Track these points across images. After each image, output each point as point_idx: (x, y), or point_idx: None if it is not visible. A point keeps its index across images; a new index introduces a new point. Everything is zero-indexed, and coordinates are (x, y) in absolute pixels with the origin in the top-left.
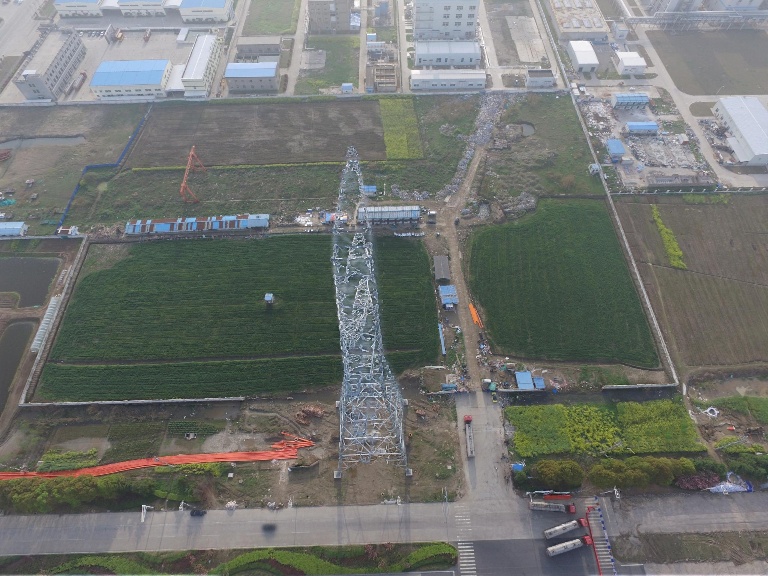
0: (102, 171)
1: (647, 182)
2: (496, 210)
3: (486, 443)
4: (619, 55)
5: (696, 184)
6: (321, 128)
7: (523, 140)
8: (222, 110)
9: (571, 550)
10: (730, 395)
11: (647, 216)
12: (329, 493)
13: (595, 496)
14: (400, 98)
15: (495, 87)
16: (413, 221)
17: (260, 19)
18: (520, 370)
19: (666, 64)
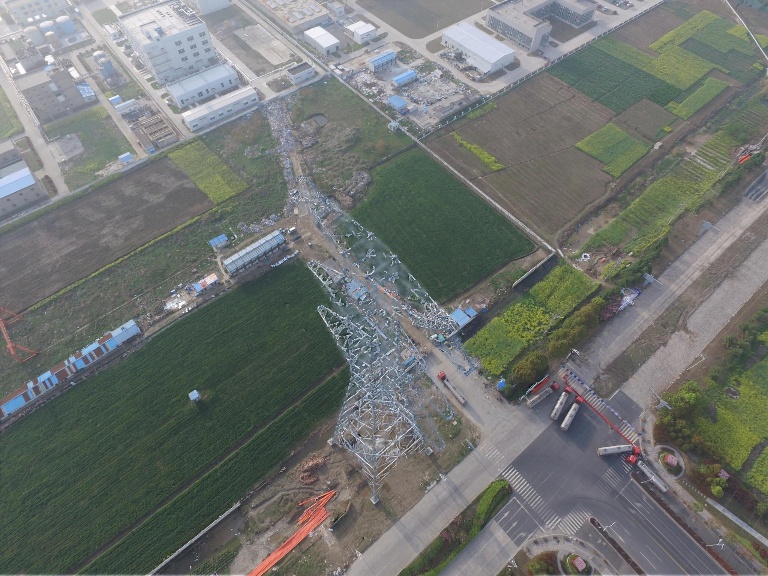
0: None
1: (437, 118)
2: (343, 198)
3: (467, 384)
4: (350, 28)
5: (469, 103)
6: (126, 209)
7: (323, 130)
8: None
9: (575, 415)
10: (587, 238)
11: (454, 143)
12: (379, 520)
13: (562, 366)
14: (187, 144)
15: (268, 96)
16: (280, 246)
17: None
18: (450, 312)
19: (388, 22)
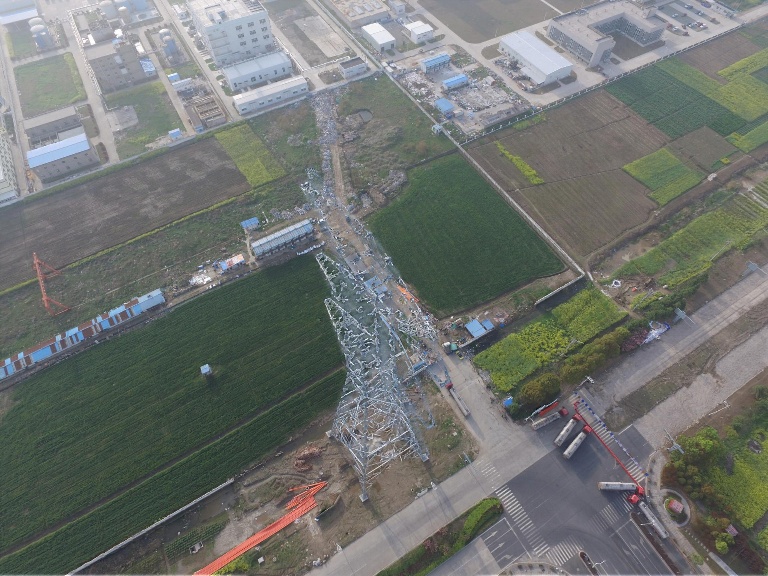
0: None
1: (482, 125)
2: (376, 195)
3: (473, 397)
4: (408, 27)
5: (518, 113)
6: (168, 183)
7: (367, 126)
8: (44, 204)
9: (581, 444)
10: (621, 265)
11: (496, 152)
12: (365, 518)
13: (574, 392)
14: (234, 126)
15: (318, 87)
16: (308, 235)
17: (37, 95)
18: (467, 322)
19: (447, 24)
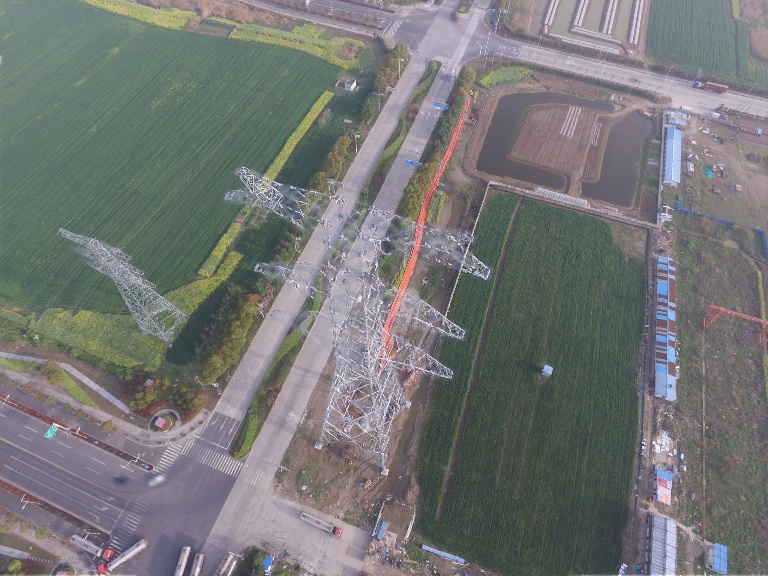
0: (756, 245)
1: None
2: None
3: (308, 542)
4: None
5: None
6: None
7: None
8: None
9: (175, 572)
10: None
11: None
12: None
13: None
14: None
15: None
16: None
17: None
18: None
19: None
